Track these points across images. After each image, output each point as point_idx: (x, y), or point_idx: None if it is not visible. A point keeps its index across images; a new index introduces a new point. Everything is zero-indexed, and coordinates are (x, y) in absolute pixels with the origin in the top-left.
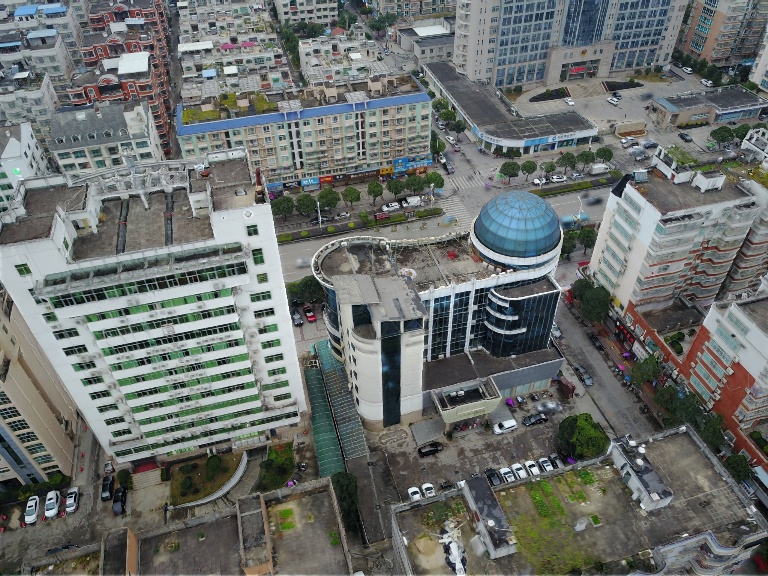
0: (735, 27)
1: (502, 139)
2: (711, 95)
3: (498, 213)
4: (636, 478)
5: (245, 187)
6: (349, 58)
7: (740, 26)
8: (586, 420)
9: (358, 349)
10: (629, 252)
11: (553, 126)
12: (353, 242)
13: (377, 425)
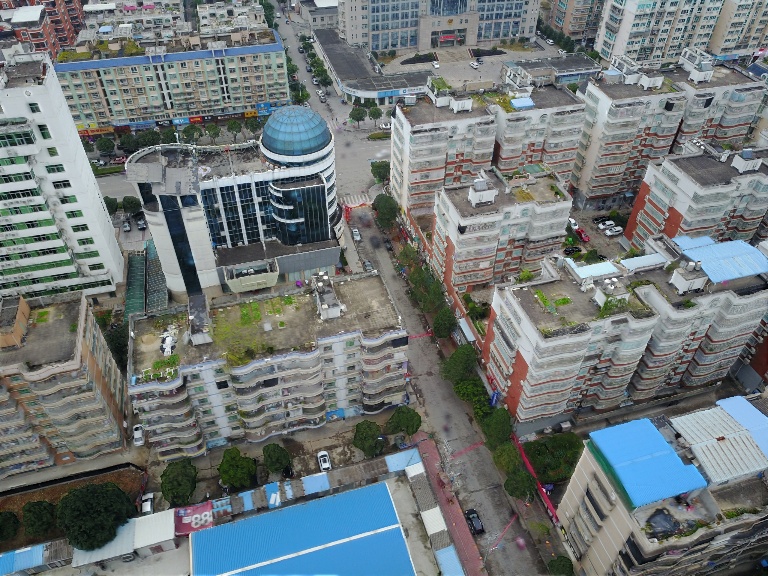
0: (587, 3)
1: (358, 90)
2: (556, 60)
3: (273, 120)
4: (318, 297)
5: (36, 78)
6: None
7: (591, 2)
8: None
9: (148, 222)
10: (402, 164)
11: (408, 82)
12: (167, 147)
13: (182, 297)
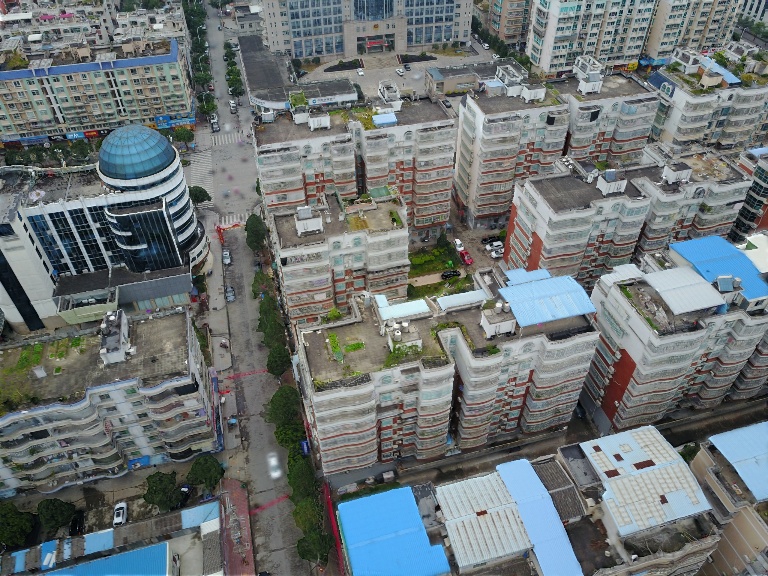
0: (520, 5)
1: (265, 101)
2: (482, 66)
3: (105, 141)
4: None
5: None
6: (153, 28)
7: (526, 4)
8: None
9: None
10: None
11: (321, 91)
12: (7, 170)
13: (21, 328)
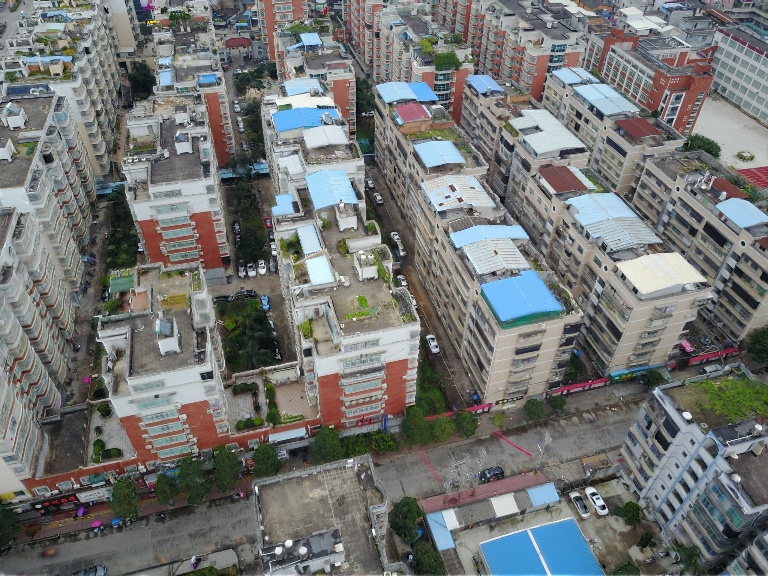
0: None
1: None
2: None
3: None
4: (315, 561)
5: None
6: None
7: None
8: None
9: None
10: None
11: None
12: None
13: None
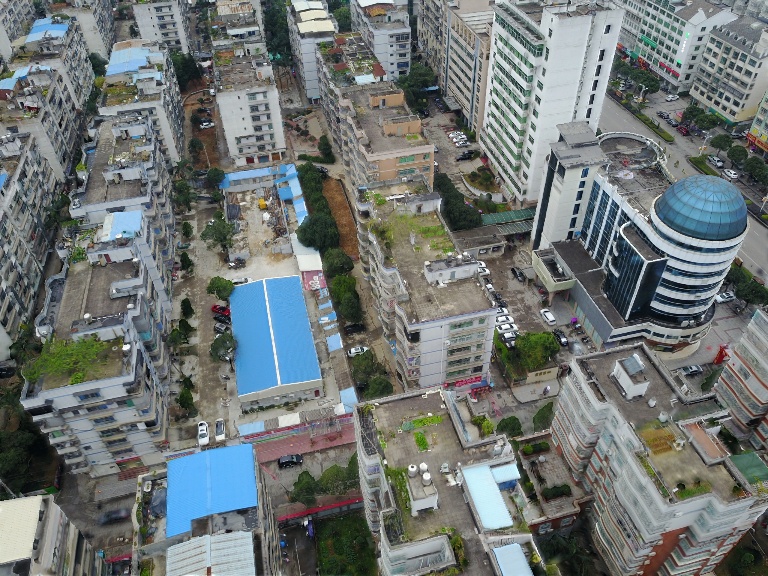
0: None
1: None
2: None
3: None
4: None
5: None
6: None
7: None
8: (548, 339)
9: None
10: None
11: None
12: (653, 147)
13: None
